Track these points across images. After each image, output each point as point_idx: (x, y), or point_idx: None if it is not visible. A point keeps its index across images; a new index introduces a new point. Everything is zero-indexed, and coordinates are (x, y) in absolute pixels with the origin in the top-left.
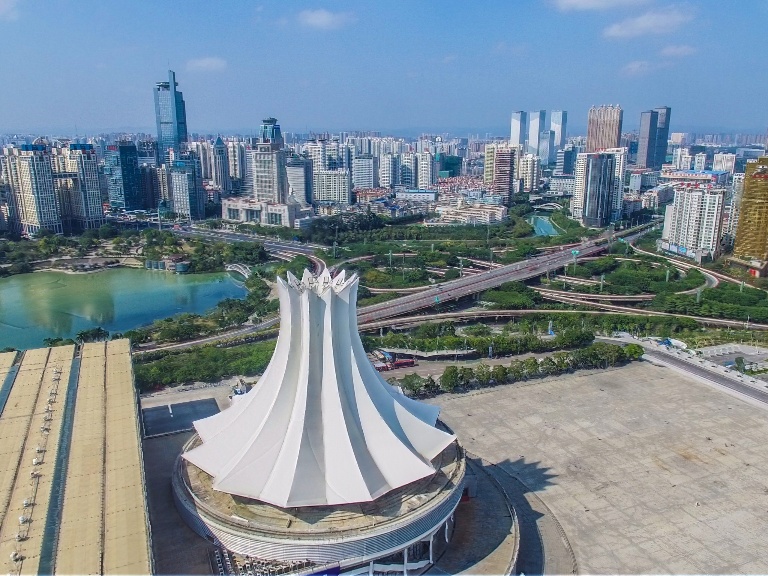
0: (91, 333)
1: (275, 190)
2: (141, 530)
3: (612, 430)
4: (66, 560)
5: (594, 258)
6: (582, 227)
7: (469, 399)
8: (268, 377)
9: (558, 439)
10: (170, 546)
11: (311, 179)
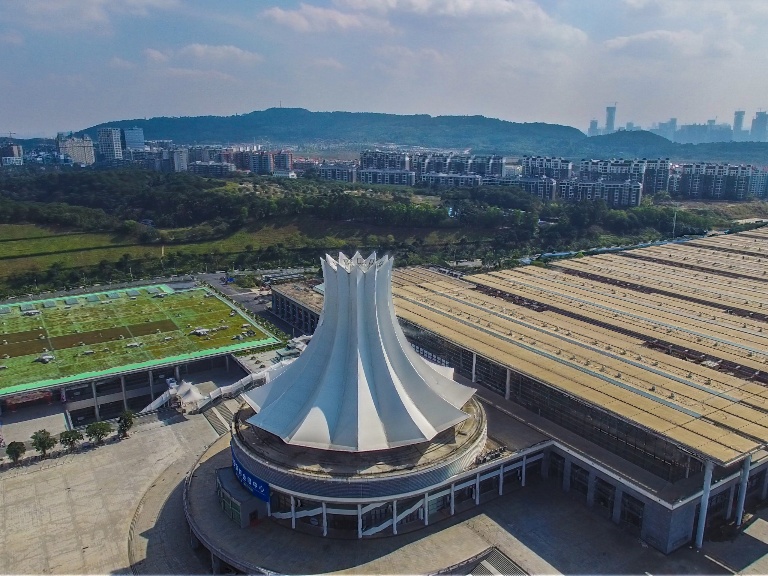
0: None
1: None
2: None
3: None
4: None
5: None
6: None
7: None
8: None
9: None
10: None
11: None
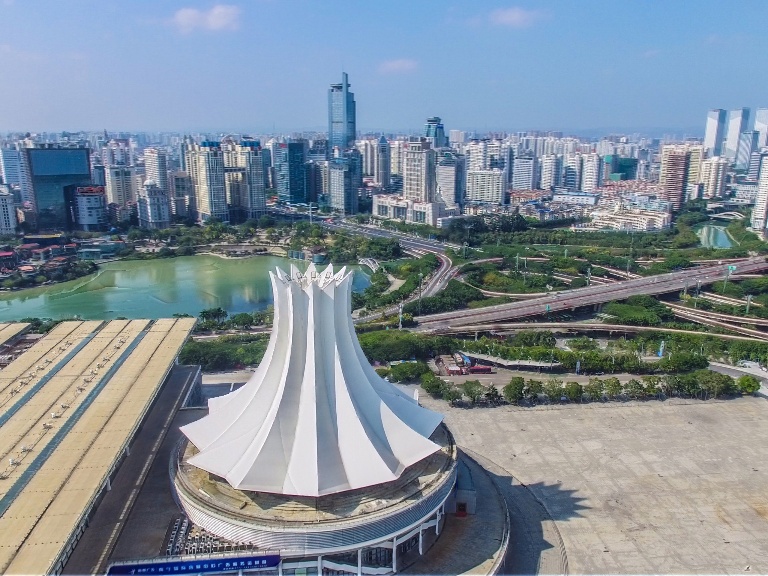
0: (212, 312)
1: (422, 188)
2: (93, 487)
3: (680, 469)
4: (22, 501)
5: (756, 276)
6: (759, 240)
7: (530, 414)
8: (261, 364)
9: (610, 469)
10: (147, 508)
11: (462, 178)
